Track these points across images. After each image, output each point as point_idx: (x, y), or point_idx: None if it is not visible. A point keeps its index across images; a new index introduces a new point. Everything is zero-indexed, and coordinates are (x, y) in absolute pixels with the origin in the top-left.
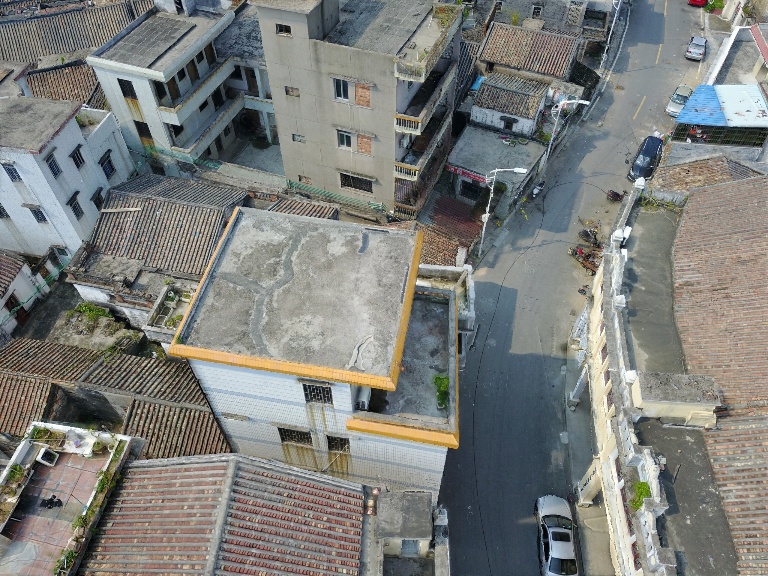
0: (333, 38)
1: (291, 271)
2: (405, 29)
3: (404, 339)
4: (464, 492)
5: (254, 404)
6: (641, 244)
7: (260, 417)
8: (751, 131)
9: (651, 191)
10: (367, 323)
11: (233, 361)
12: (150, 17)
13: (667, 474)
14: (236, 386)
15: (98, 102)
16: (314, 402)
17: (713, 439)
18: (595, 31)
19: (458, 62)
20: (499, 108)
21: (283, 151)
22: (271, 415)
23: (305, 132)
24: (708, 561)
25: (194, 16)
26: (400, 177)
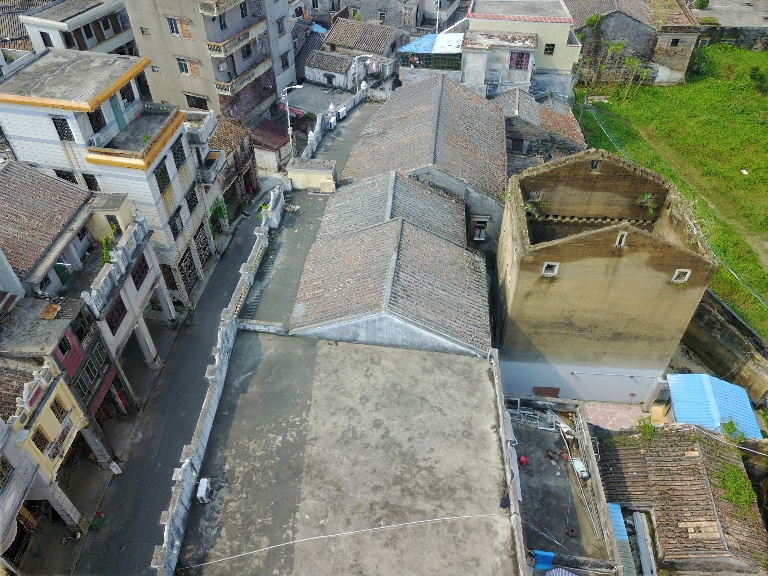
0: None
1: (63, 71)
2: None
3: (108, 93)
4: (225, 285)
5: (36, 149)
6: (355, 120)
7: (43, 162)
8: (450, 58)
9: (372, 91)
10: (92, 88)
11: (9, 99)
12: None
13: (297, 213)
14: (22, 130)
15: None
16: (65, 140)
17: (332, 196)
18: (426, 31)
19: (267, 19)
20: (322, 67)
21: (148, 81)
22: (48, 158)
23: (159, 63)
24: (297, 245)
25: None
26: (220, 93)
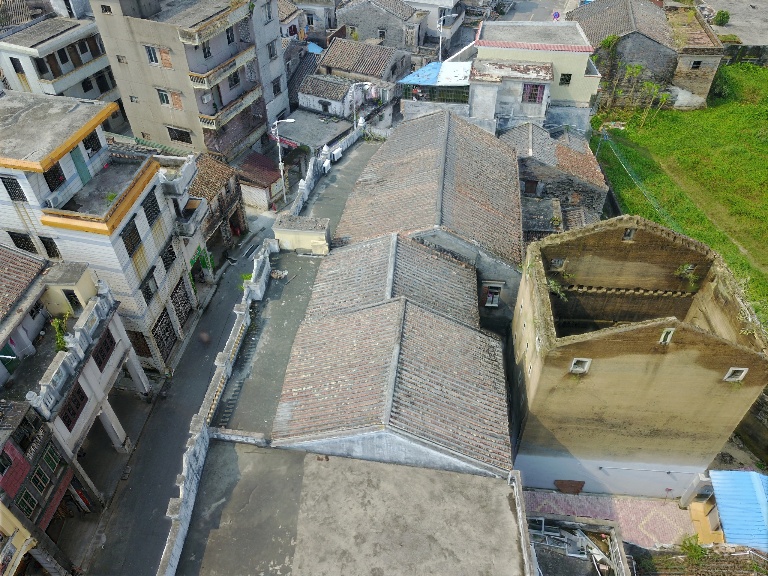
0: (148, 19)
1: (17, 120)
2: (204, 15)
3: (64, 149)
4: (207, 347)
5: None
6: (351, 162)
7: None
8: (456, 90)
9: (370, 128)
10: (47, 142)
11: None
12: (48, 19)
13: (284, 280)
14: None
15: (8, 84)
16: (17, 201)
17: (324, 260)
18: (428, 50)
19: (256, 45)
20: (316, 94)
21: (127, 111)
22: None
23: (137, 93)
24: (283, 323)
25: (82, 19)
26: (205, 127)
